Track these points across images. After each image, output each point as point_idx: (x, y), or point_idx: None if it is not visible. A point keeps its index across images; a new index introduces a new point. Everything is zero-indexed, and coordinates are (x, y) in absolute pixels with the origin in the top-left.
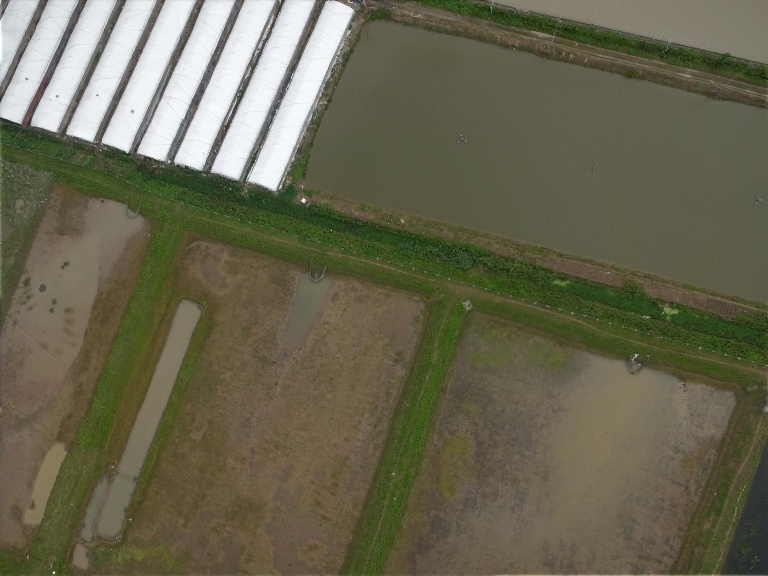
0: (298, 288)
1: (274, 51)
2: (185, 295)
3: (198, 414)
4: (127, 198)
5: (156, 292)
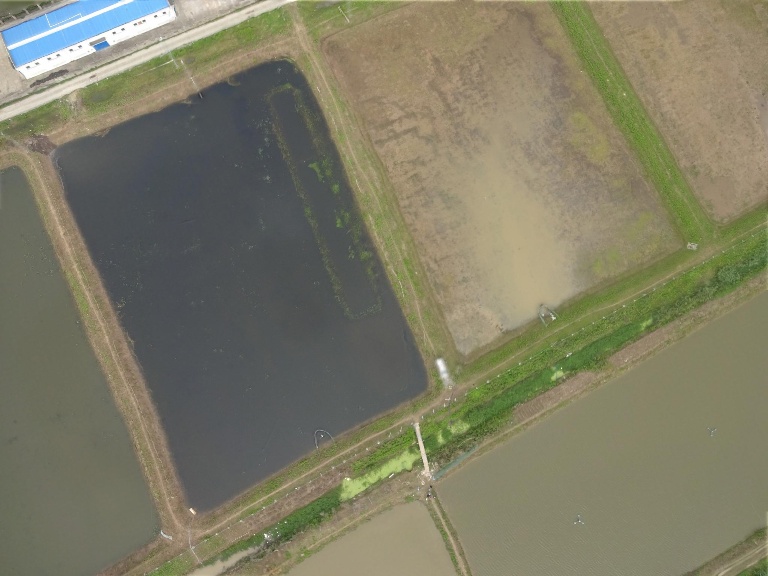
0: None
1: None
2: None
3: None
4: None
5: None
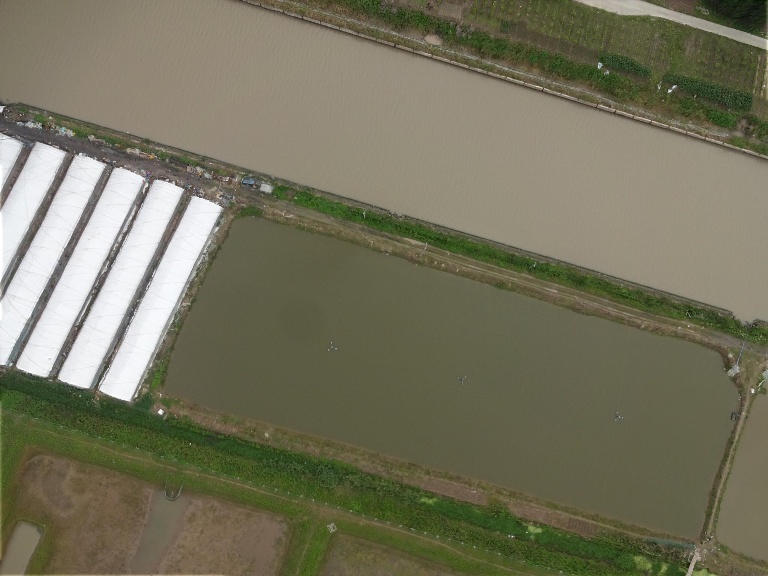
0: (151, 507)
1: (133, 250)
2: (22, 517)
3: None
4: None
5: None
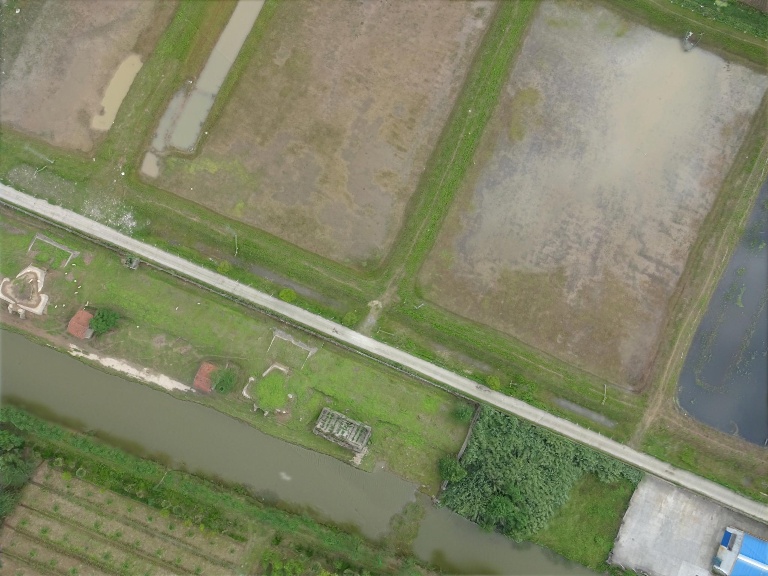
0: None
1: None
2: None
3: (283, 41)
4: None
5: None
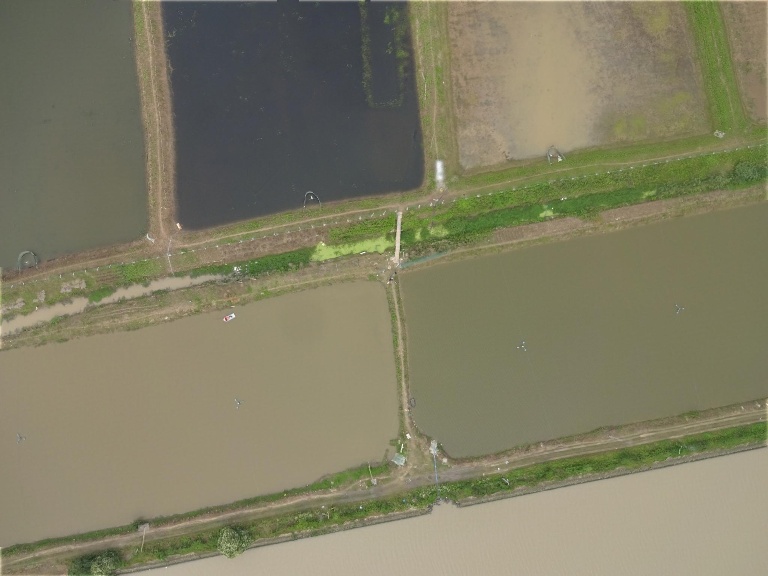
0: None
1: None
2: None
3: None
4: None
5: None
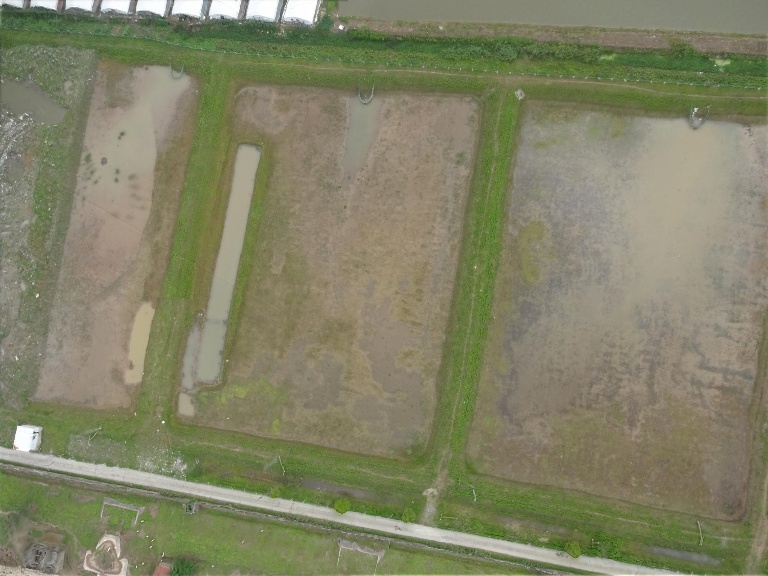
0: (350, 112)
1: None
2: (242, 140)
3: (274, 250)
4: (170, 59)
5: (214, 141)
